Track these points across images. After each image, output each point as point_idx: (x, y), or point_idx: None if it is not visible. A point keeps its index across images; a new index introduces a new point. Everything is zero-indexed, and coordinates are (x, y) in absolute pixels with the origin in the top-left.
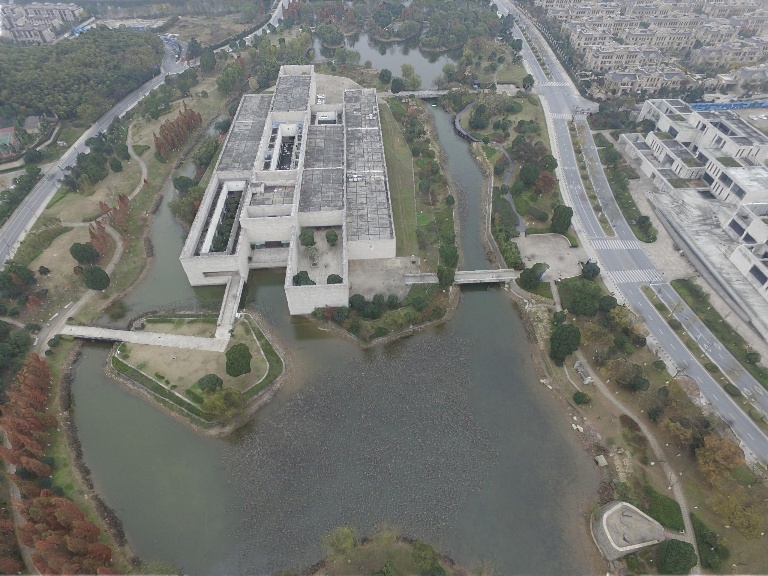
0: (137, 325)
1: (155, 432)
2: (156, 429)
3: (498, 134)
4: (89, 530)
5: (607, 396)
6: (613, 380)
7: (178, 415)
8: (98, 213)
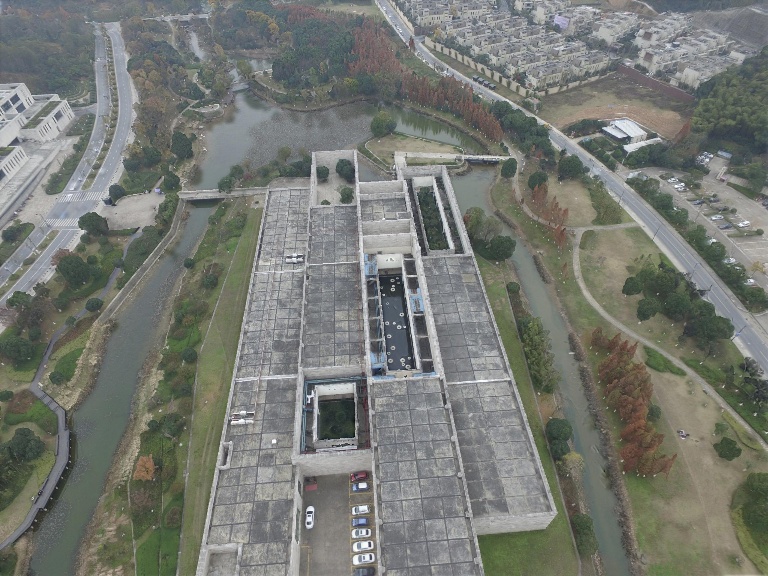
0: None
1: None
2: None
3: (10, 416)
4: (418, 94)
5: None
6: None
7: None
8: (588, 242)
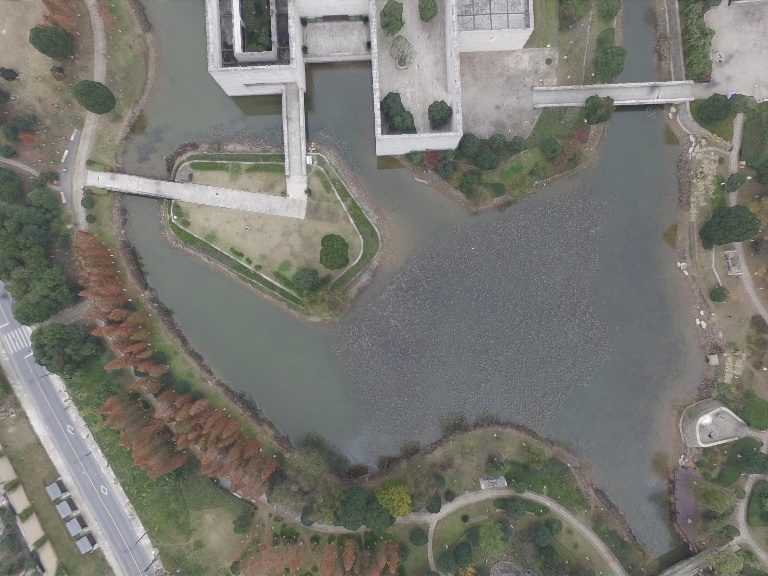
0: (183, 178)
1: (251, 311)
2: (251, 308)
3: None
4: (235, 432)
5: (748, 291)
6: (767, 281)
7: (272, 298)
8: None
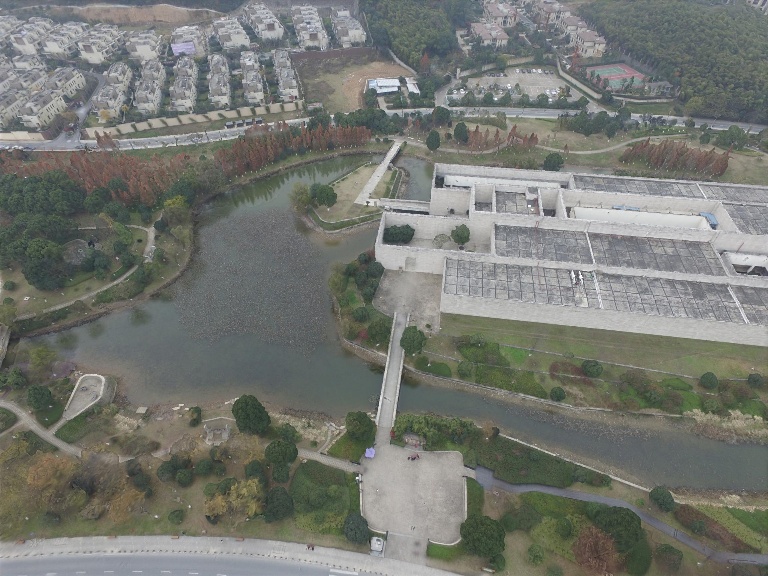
0: None
1: None
2: None
3: None
4: (251, 160)
5: None
6: None
7: None
8: None
